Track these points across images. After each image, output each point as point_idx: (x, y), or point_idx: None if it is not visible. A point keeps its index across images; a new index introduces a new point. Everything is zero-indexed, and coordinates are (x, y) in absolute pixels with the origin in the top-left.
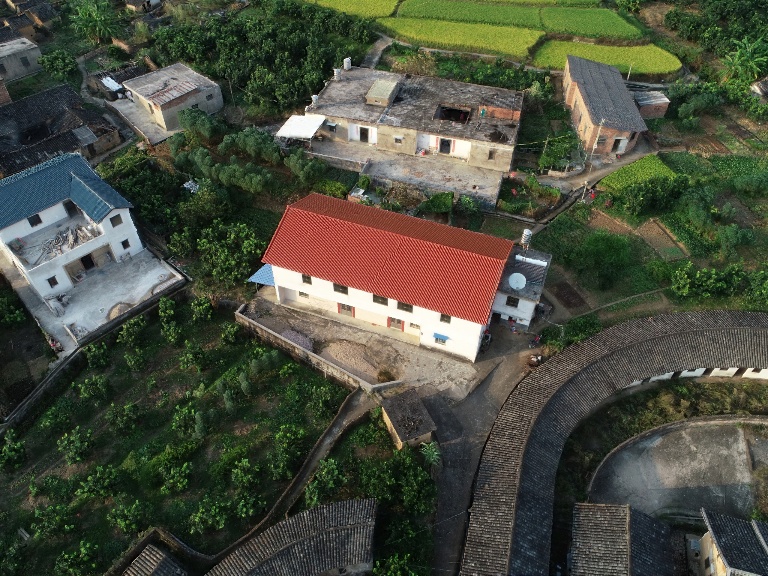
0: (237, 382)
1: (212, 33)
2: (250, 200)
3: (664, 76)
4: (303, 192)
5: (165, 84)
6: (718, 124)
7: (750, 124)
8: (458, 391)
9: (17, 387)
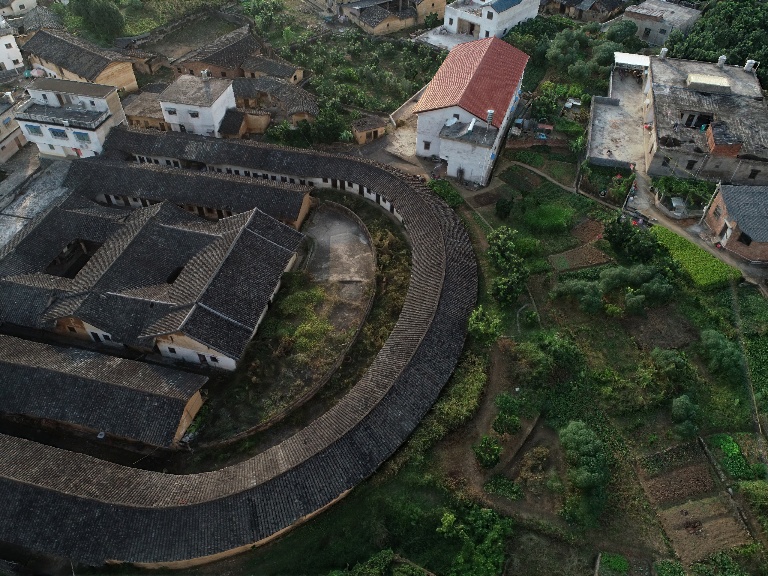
0: (400, 89)
1: (761, 13)
2: (548, 65)
3: None
4: (567, 83)
5: (662, 10)
6: None
7: None
8: (392, 149)
9: (391, 37)
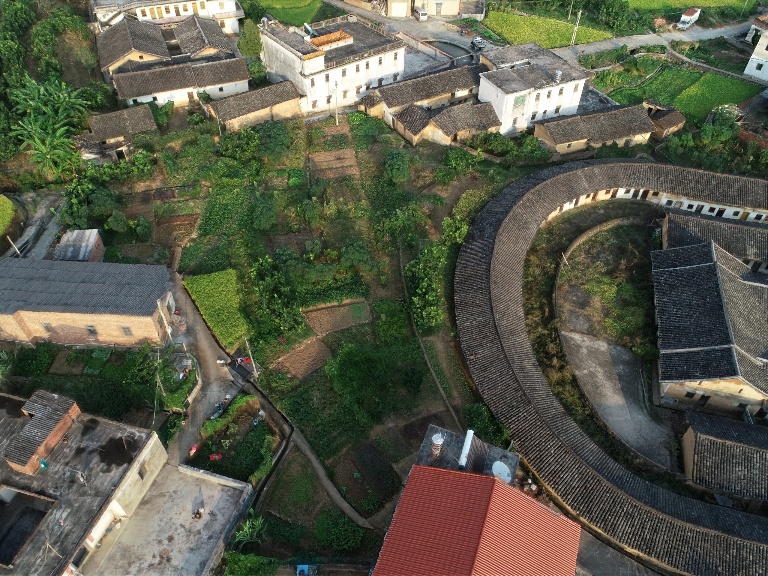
0: None
1: None
2: None
3: (17, 218)
4: None
5: None
6: (137, 207)
7: (149, 184)
8: None
9: None
